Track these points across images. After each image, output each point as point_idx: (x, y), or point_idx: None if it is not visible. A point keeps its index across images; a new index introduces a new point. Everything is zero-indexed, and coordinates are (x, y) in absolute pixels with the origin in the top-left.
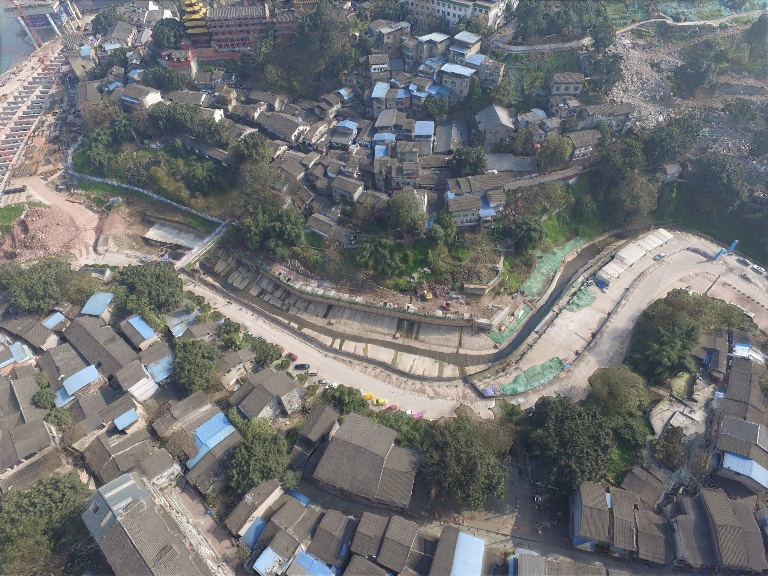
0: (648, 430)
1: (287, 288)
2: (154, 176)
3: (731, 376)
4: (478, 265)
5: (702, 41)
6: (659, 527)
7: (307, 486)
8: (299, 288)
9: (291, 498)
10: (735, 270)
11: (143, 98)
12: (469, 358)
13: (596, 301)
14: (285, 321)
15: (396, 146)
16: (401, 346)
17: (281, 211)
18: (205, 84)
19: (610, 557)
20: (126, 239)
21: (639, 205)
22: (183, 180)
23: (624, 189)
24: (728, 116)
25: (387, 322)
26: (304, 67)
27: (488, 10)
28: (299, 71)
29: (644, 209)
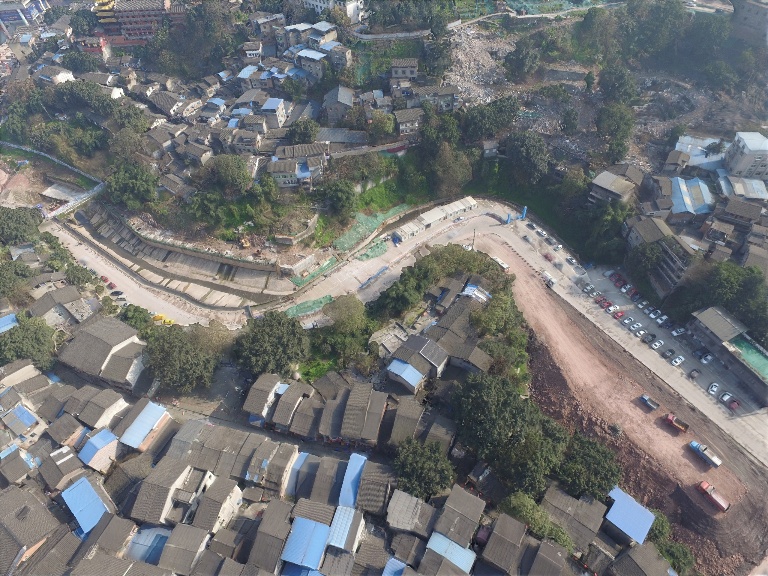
0: (365, 349)
1: (138, 236)
2: (53, 142)
3: (450, 309)
4: (292, 220)
5: (536, 32)
6: (315, 410)
7: (68, 373)
8: (144, 235)
9: (40, 375)
10: (521, 233)
11: (54, 77)
12: (270, 297)
13: (386, 253)
14: (131, 263)
15: (244, 118)
16: (217, 286)
17: (137, 170)
18: (115, 67)
19: (277, 434)
20: (26, 195)
21: (449, 174)
22: (76, 146)
23: (438, 160)
24: (550, 99)
25: (211, 266)
26: (196, 53)
27: (344, 3)
28: (189, 56)
29: (456, 179)
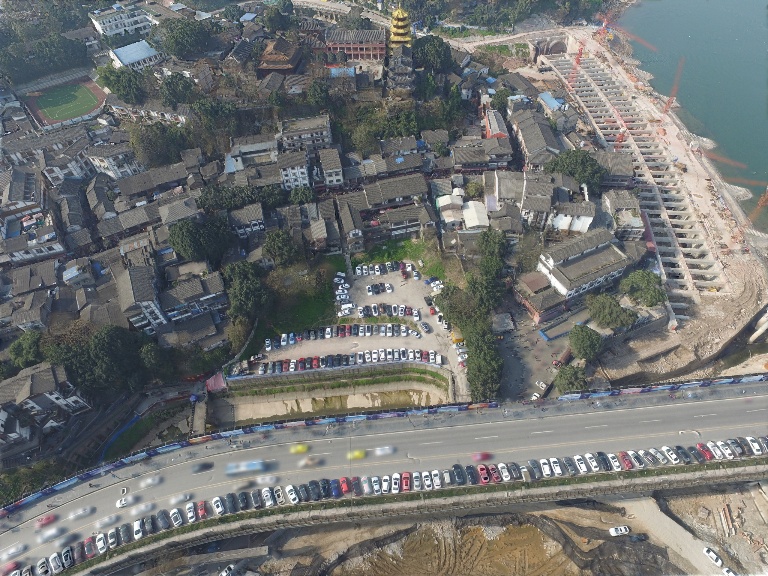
0: None
1: None
2: None
3: None
4: None
5: None
6: None
7: None
8: None
9: None
10: None
11: None
12: None
13: None
14: None
15: None
16: None
17: None
18: None
19: None
20: None
21: None
22: None
23: None
24: None
25: None
26: None
27: None
28: None
29: None
